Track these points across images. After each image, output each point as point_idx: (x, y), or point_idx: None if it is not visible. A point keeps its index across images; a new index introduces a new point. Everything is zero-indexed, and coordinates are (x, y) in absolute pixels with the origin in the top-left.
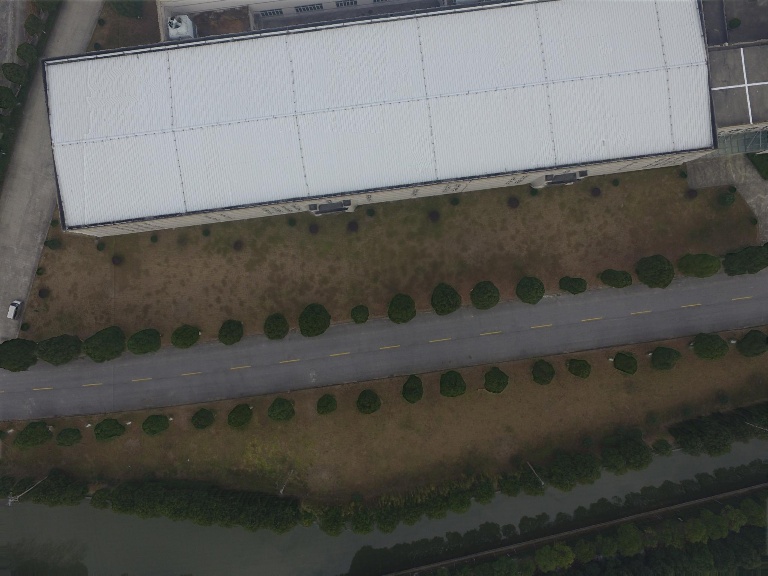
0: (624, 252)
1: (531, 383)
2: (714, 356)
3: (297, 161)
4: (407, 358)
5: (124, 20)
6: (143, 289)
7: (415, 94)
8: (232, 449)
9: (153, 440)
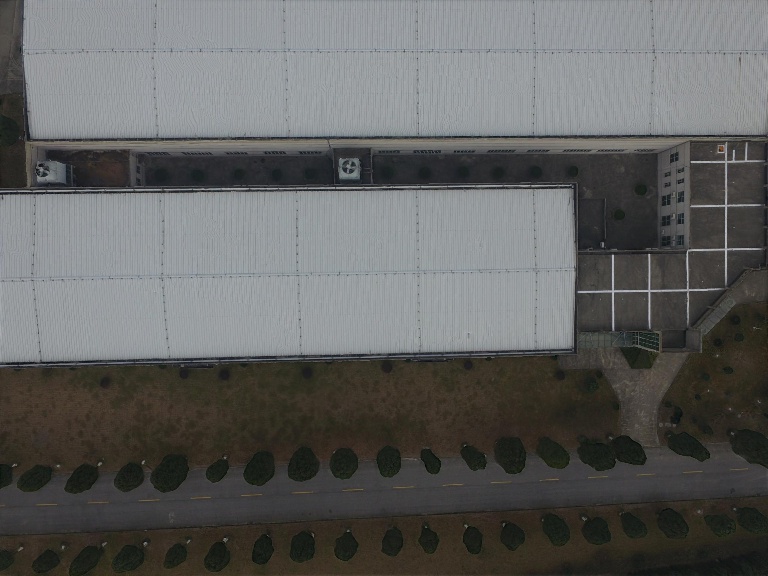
0: (490, 424)
1: None
2: (555, 544)
3: (160, 323)
4: (268, 507)
5: None
6: (2, 416)
7: (286, 269)
8: None
9: None
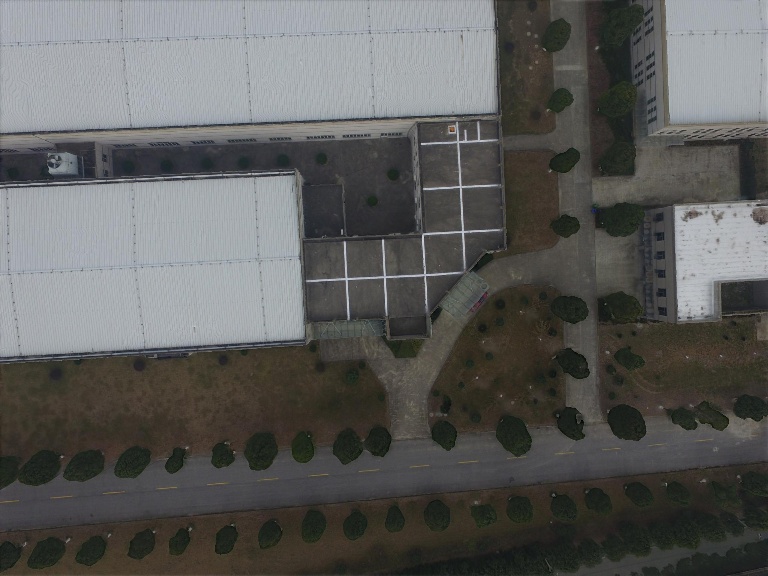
0: (252, 420)
1: None
2: (305, 541)
3: None
4: (26, 513)
5: None
6: None
7: None
8: None
9: None
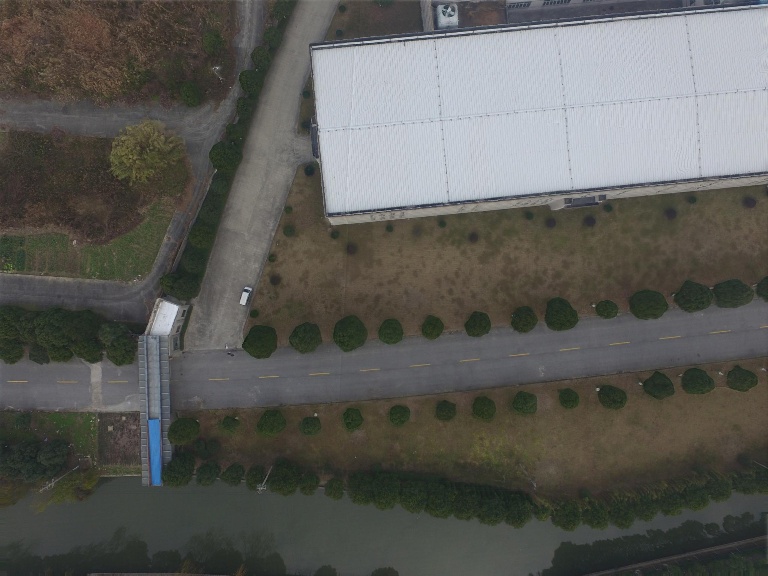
0: None
1: (761, 382)
2: None
3: (563, 154)
4: (636, 355)
5: (365, 7)
6: (375, 279)
7: (684, 91)
8: (460, 442)
9: (380, 431)
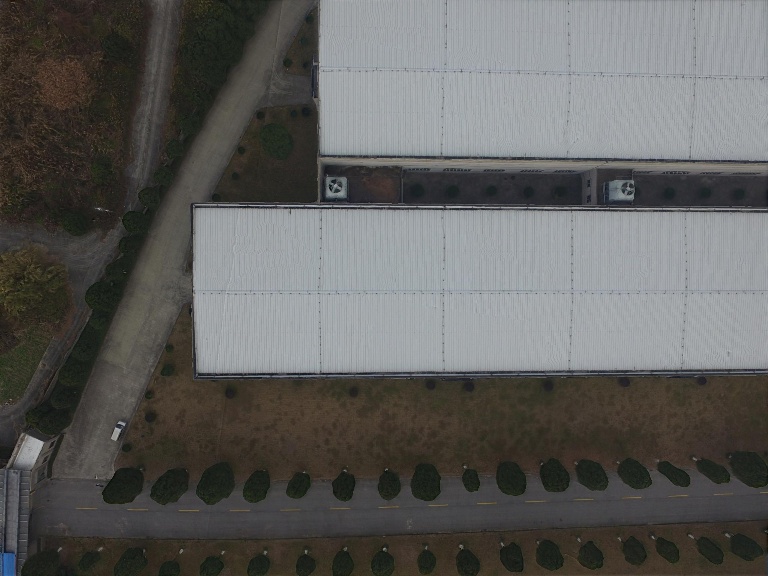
0: (717, 437)
1: (615, 551)
2: None
3: (437, 337)
4: (502, 515)
5: None
6: (252, 423)
7: (561, 287)
8: None
9: (244, 570)
